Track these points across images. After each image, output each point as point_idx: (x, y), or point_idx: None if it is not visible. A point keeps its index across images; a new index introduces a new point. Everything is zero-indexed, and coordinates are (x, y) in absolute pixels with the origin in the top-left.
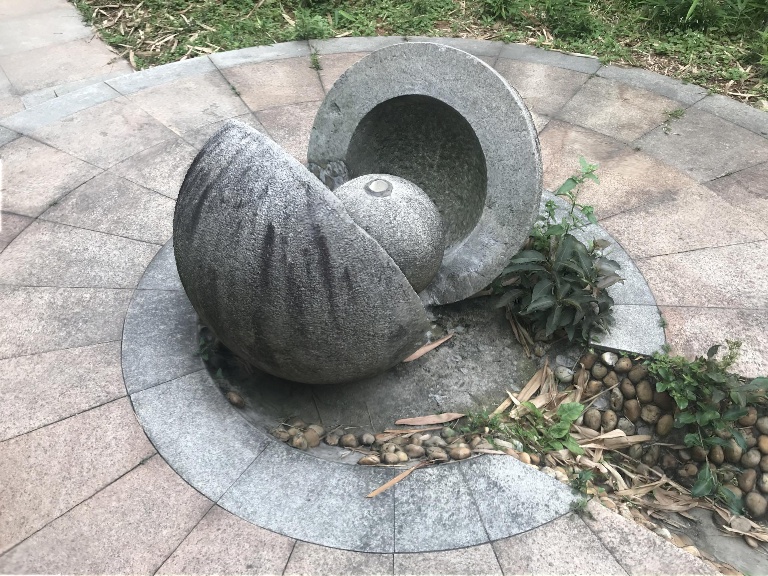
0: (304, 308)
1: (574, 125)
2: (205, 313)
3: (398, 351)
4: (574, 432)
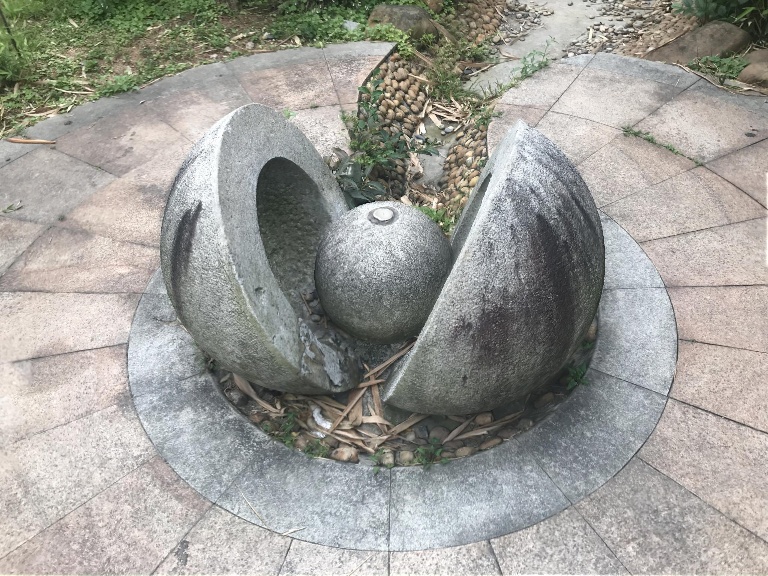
0: None
1: (8, 271)
2: None
3: None
4: None
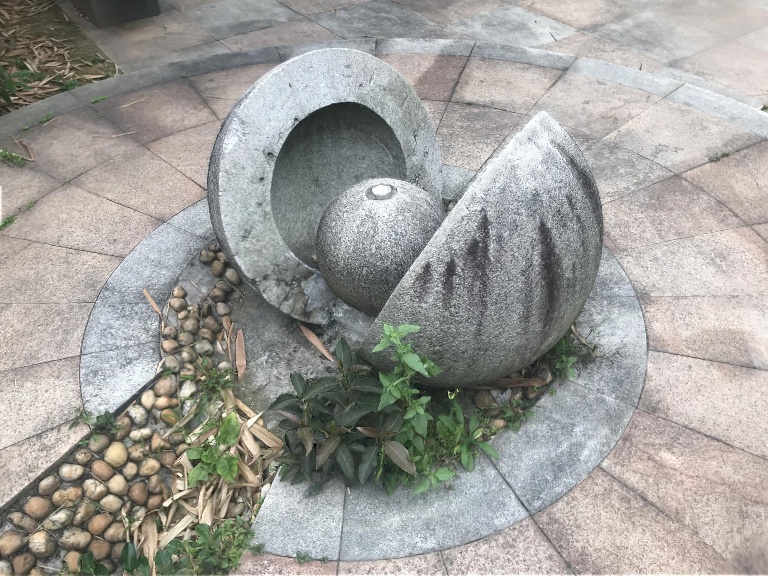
0: None
1: None
2: None
3: None
4: None
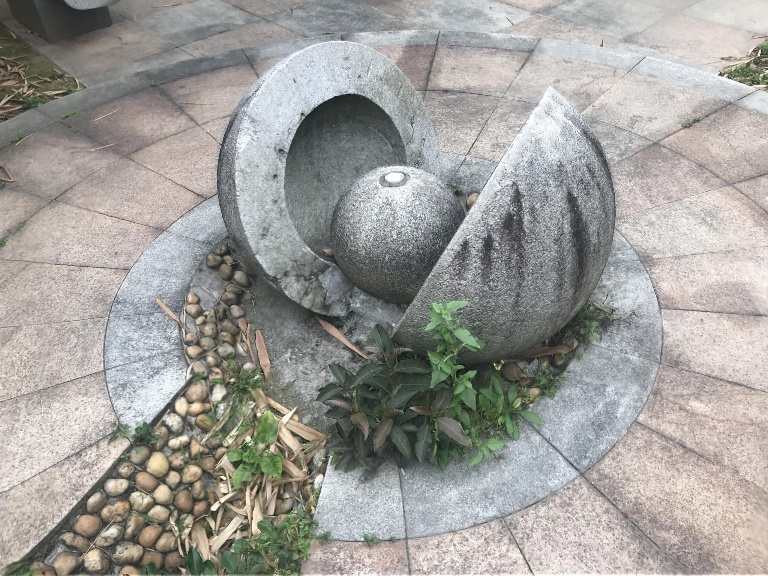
0: None
1: None
2: None
3: None
4: None
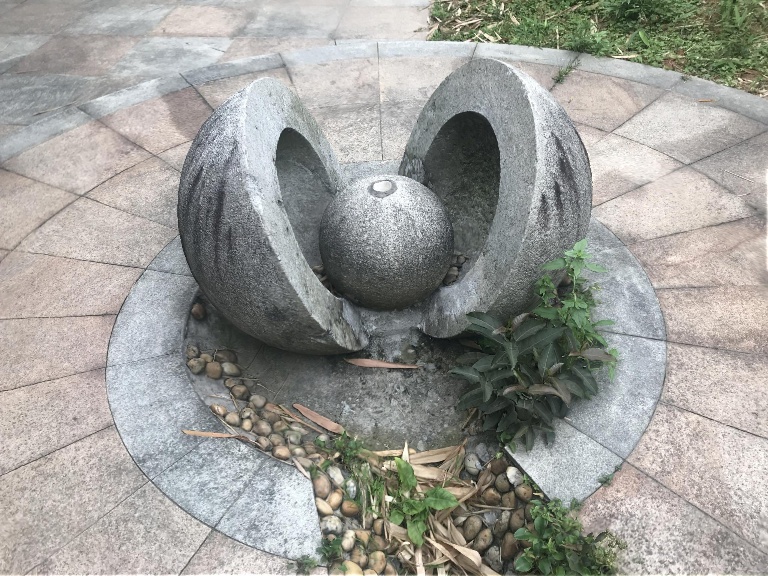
0: (201, 248)
1: None
2: None
3: (285, 333)
4: (444, 525)
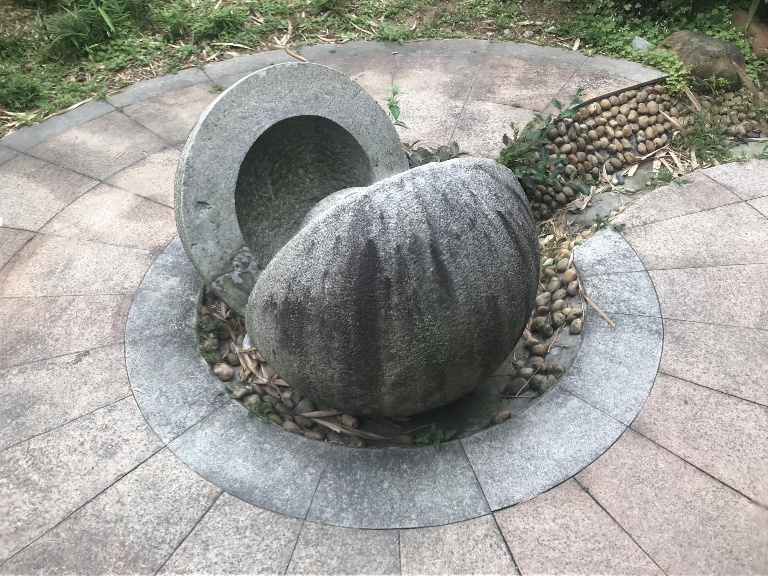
0: None
1: None
2: (482, 359)
3: None
4: None
